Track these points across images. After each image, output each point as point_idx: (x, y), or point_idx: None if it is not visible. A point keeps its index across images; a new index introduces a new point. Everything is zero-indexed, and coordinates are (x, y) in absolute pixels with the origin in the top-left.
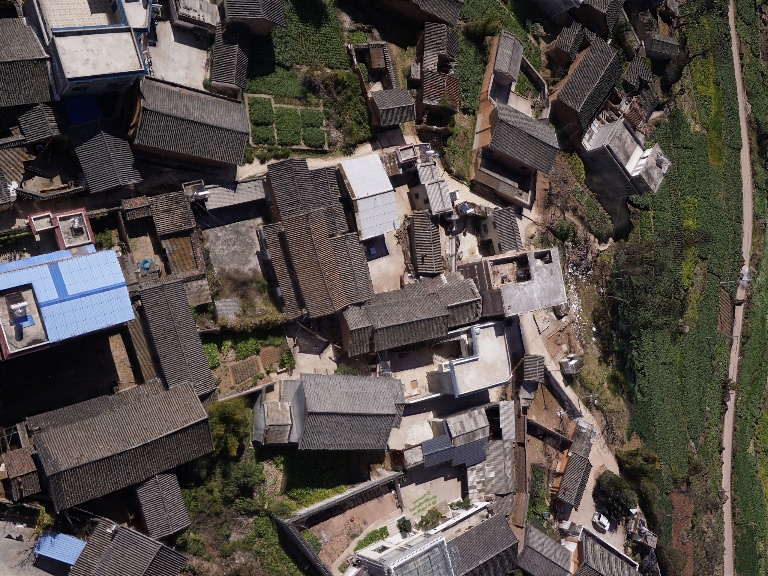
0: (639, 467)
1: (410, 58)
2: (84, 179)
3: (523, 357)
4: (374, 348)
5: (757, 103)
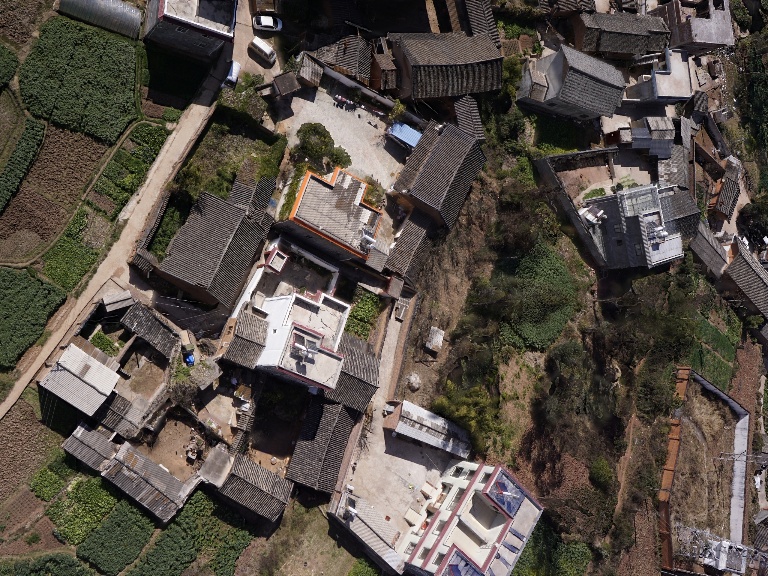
0: None
1: None
2: None
3: None
4: (600, 47)
5: None
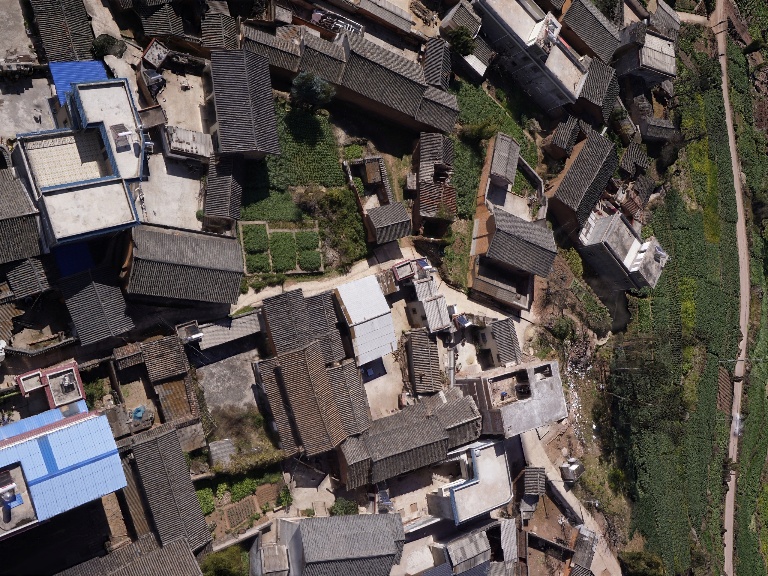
0: (642, 571)
1: (406, 167)
2: (74, 329)
3: (523, 465)
4: (373, 480)
5: (751, 171)
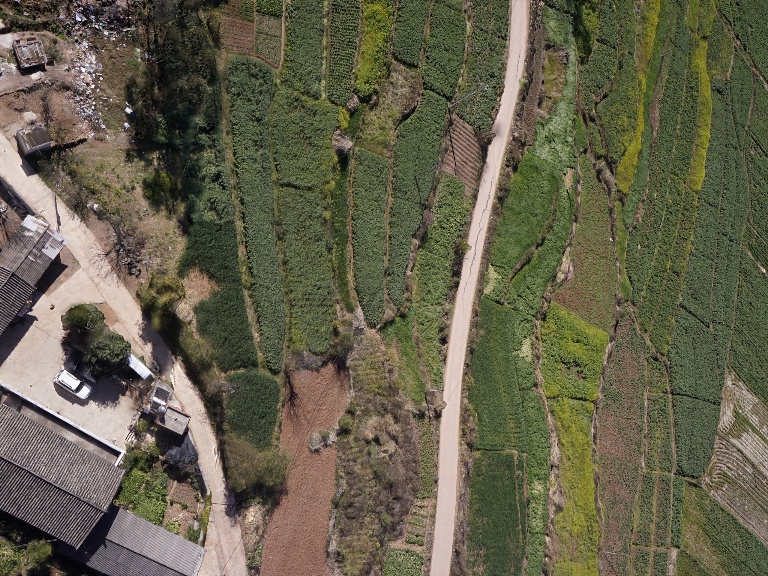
0: (155, 304)
1: None
2: None
3: None
4: None
5: None
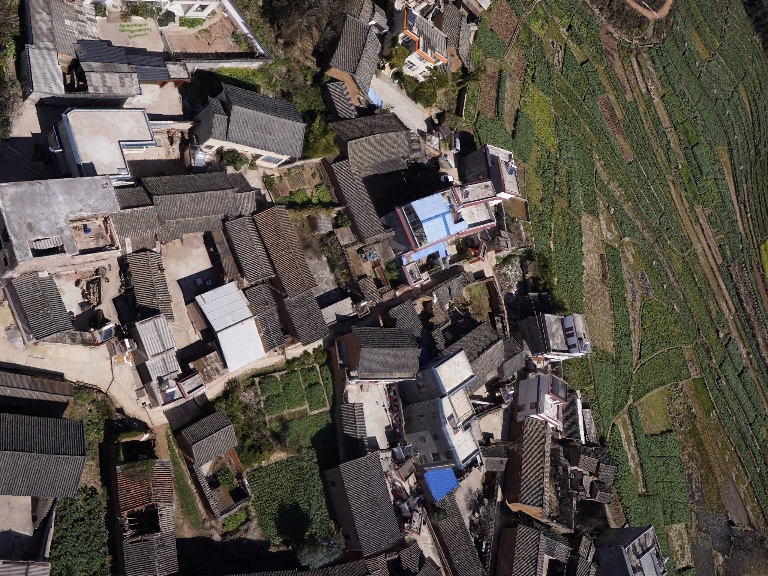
0: None
1: None
2: None
3: None
4: None
5: None
